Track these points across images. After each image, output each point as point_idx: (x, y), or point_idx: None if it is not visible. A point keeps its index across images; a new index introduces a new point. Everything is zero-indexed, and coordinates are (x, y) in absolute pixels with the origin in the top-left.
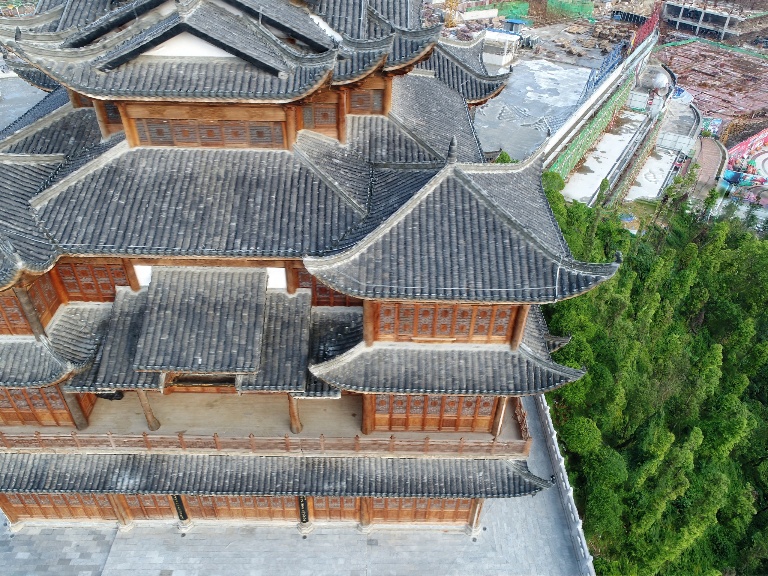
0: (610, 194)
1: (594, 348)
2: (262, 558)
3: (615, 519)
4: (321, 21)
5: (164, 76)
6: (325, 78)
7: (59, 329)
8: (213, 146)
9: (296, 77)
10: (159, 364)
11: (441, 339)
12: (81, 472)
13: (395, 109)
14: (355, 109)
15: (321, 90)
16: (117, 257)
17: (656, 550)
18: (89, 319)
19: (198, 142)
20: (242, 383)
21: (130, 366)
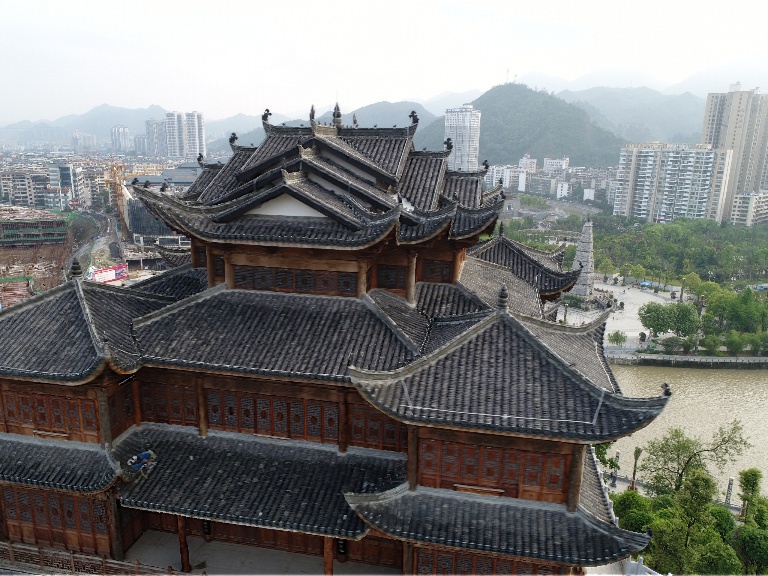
0: None
1: None
2: None
3: None
4: None
5: None
6: None
7: None
8: None
9: None
10: None
11: None
12: None
13: None
14: None
15: None
16: None
17: None
18: None
19: None
20: None
21: None
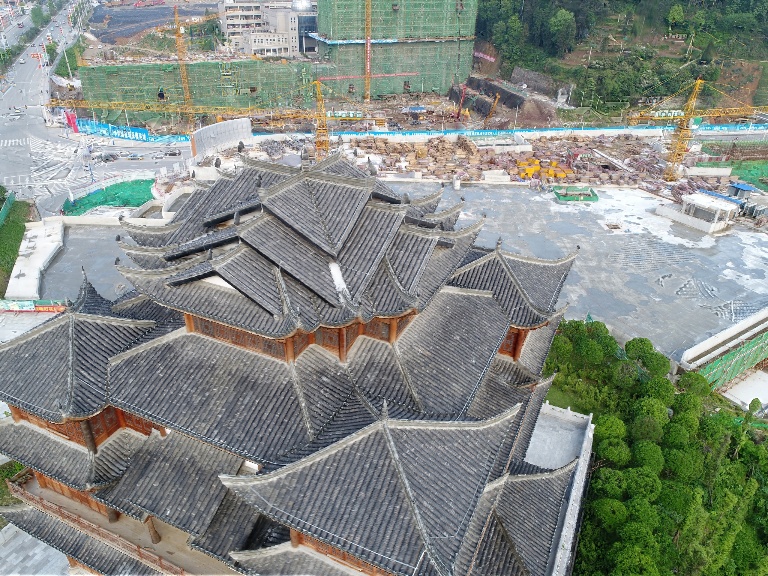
0: (764, 416)
1: None
2: None
3: None
4: (338, 270)
5: (203, 298)
6: (295, 331)
7: (109, 448)
8: (239, 345)
9: (283, 322)
10: (142, 505)
11: (350, 565)
12: (103, 554)
13: (407, 336)
14: (368, 332)
15: (299, 335)
16: (140, 417)
17: None
18: (132, 445)
19: (230, 340)
20: (194, 541)
21: None
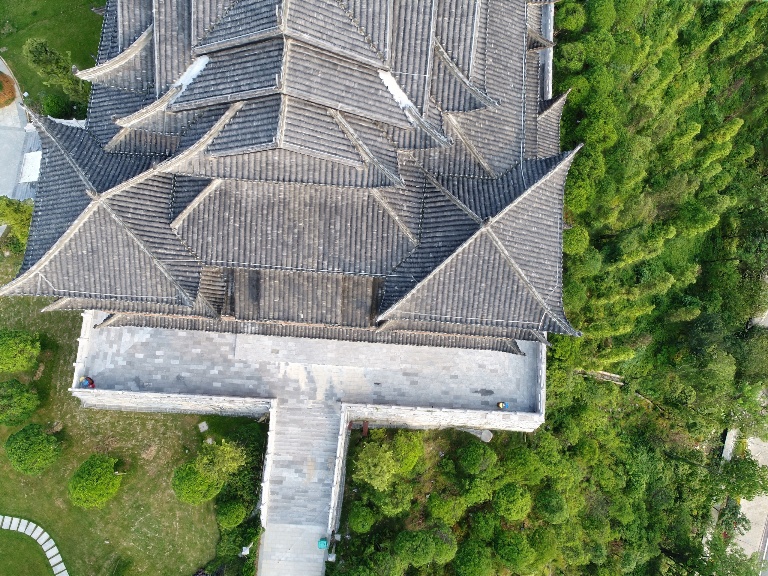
0: None
1: (609, 160)
2: (334, 345)
3: (578, 305)
4: (390, 76)
5: (263, 162)
6: None
7: None
8: None
9: (370, 173)
10: (276, 318)
11: None
12: None
13: None
14: None
15: None
16: None
17: (600, 327)
18: None
19: None
20: None
21: (255, 308)
